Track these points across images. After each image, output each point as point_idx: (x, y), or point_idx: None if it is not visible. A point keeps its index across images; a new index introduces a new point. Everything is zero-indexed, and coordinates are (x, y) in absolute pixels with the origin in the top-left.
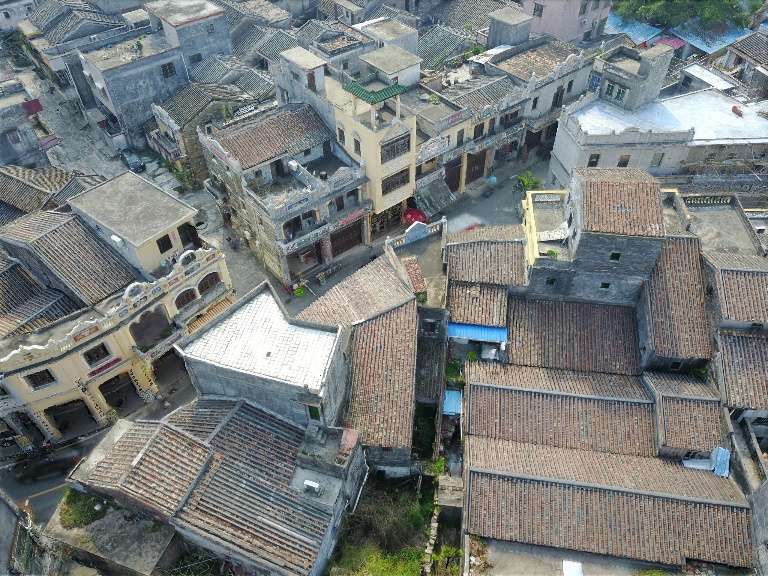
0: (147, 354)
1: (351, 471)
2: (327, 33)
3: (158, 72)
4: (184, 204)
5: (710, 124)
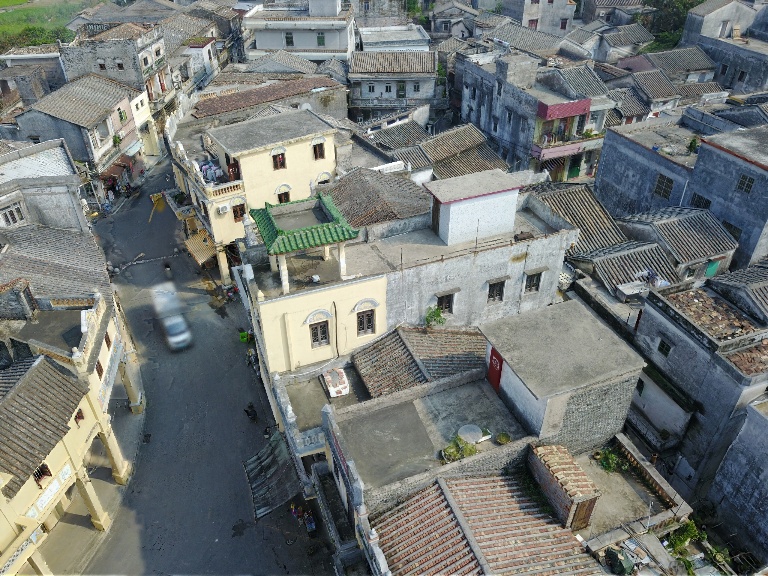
0: (165, 193)
1: None
2: (743, 294)
3: (653, 178)
4: (248, 149)
5: None
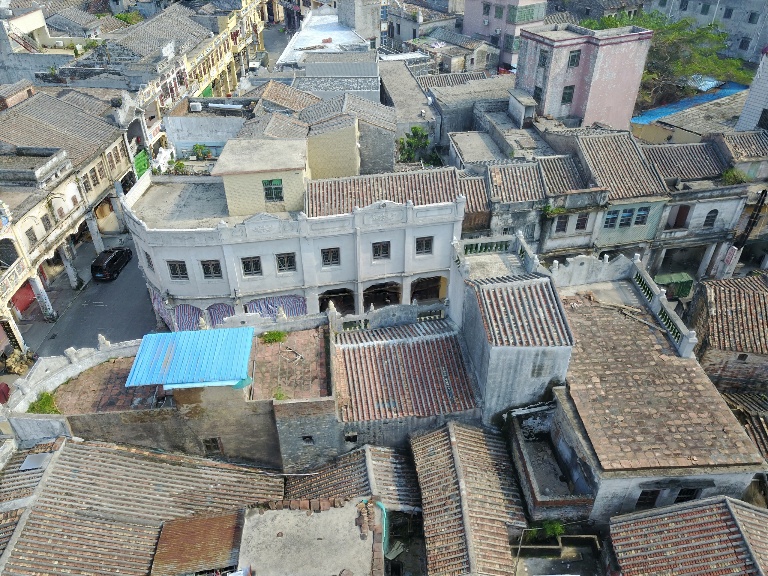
0: None
1: (164, 4)
2: None
3: None
4: None
5: (316, 36)
